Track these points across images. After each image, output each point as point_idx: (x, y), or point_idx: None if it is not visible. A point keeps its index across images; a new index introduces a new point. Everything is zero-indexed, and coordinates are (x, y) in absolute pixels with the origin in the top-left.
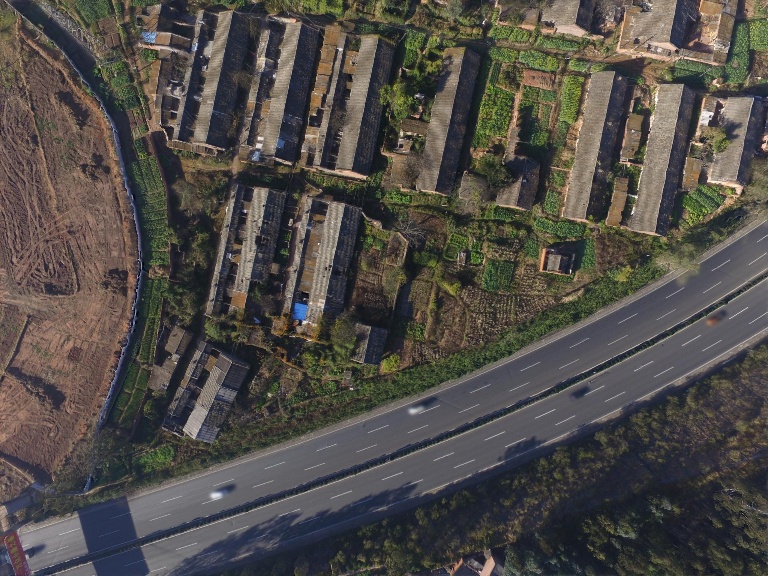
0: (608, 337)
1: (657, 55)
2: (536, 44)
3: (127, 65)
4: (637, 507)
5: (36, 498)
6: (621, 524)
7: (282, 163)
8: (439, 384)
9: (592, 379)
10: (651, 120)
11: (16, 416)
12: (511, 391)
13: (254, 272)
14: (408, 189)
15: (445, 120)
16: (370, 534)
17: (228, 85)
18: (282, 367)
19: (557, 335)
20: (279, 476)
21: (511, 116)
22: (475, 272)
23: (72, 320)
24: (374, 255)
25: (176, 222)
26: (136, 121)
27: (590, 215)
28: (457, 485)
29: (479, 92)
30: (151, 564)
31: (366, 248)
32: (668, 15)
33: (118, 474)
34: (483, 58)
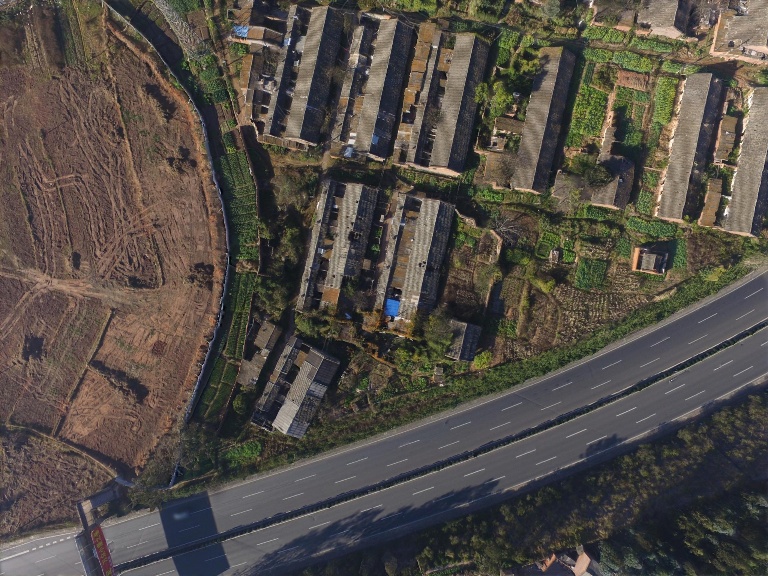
0: (688, 336)
1: (750, 58)
2: (630, 45)
3: (216, 59)
4: (731, 504)
5: (119, 492)
6: (717, 520)
7: (373, 159)
8: (523, 381)
9: (672, 378)
10: (744, 122)
11: (98, 410)
12: (593, 389)
13: (347, 268)
14: (502, 187)
15: (542, 119)
16: (456, 530)
17: (321, 80)
18: (371, 363)
19: (638, 334)
20: (361, 472)
21: (605, 116)
22: (568, 270)
23: (156, 314)
24: (466, 252)
25: (265, 217)
26: (224, 115)
27: (686, 215)
28: (539, 482)
29: (573, 92)
30: (232, 559)
31: (458, 245)
32: (764, 19)
33: (203, 469)
34: (577, 58)
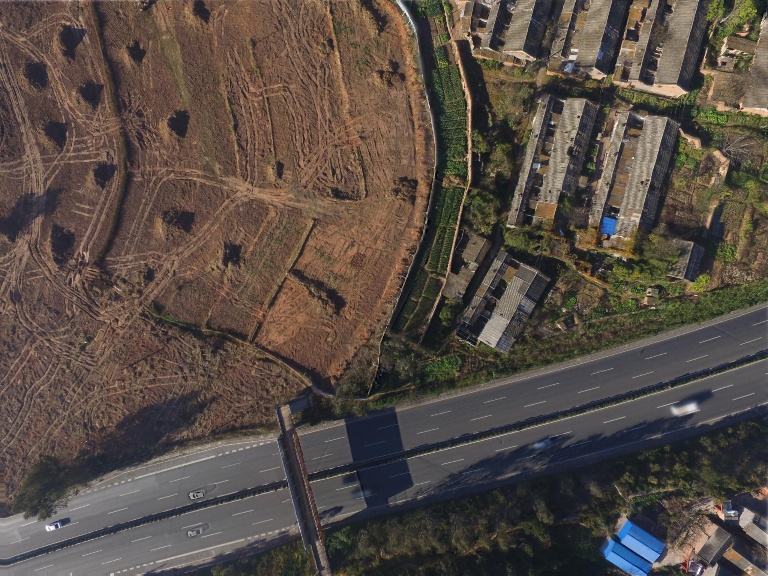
0: None
1: None
2: None
3: None
4: None
5: (313, 401)
6: None
7: (590, 77)
8: None
9: None
10: None
11: (295, 319)
12: None
13: (565, 183)
14: (730, 107)
15: None
16: (654, 458)
17: None
18: (580, 282)
19: None
20: (552, 397)
21: None
22: None
23: (357, 226)
24: (686, 174)
25: None
26: (437, 29)
27: None
28: (735, 418)
29: None
30: (416, 477)
31: (678, 166)
32: None
33: (401, 381)
34: None
